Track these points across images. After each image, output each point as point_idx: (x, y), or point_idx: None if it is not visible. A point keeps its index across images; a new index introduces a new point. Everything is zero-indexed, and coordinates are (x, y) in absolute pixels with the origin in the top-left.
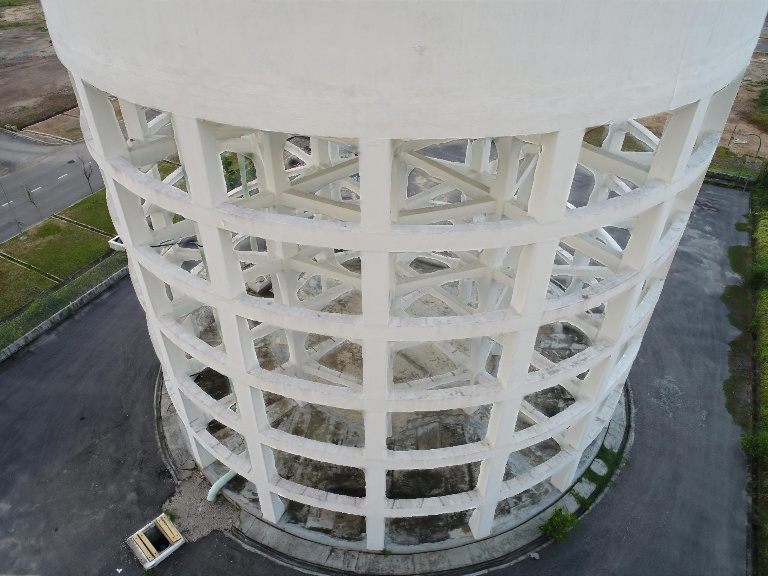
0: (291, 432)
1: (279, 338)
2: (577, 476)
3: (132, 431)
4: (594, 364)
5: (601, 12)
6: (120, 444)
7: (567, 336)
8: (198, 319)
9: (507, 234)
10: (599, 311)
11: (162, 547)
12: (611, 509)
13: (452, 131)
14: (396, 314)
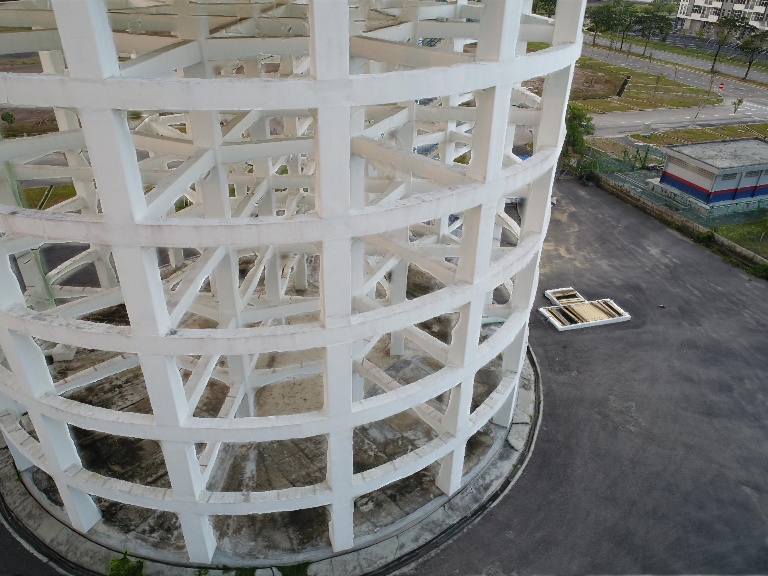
0: None
1: None
2: (227, 562)
3: (66, 300)
4: (101, 347)
5: None
6: None
7: None
8: None
9: None
10: (545, 453)
11: None
12: None
13: None
14: None
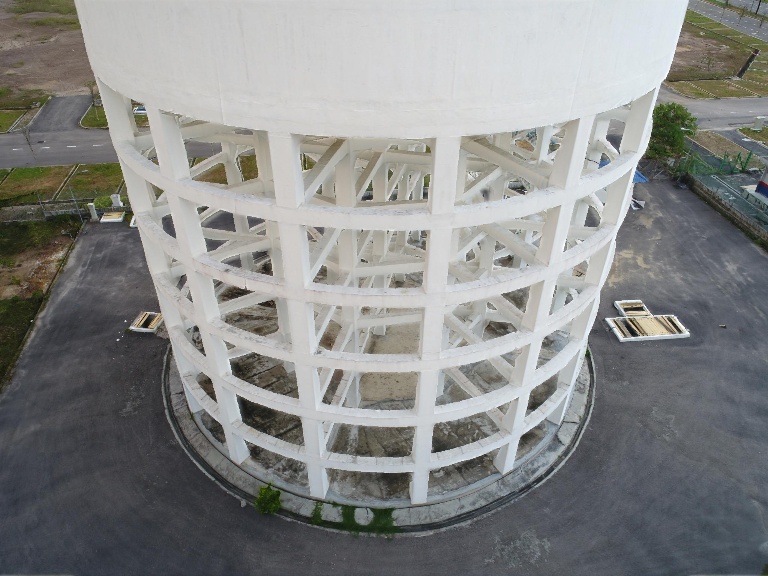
0: (256, 327)
1: None
2: (336, 500)
3: None
4: (271, 355)
5: (137, 22)
6: None
7: None
8: None
9: (148, 173)
10: (587, 449)
11: None
12: (326, 543)
13: (106, 81)
14: None
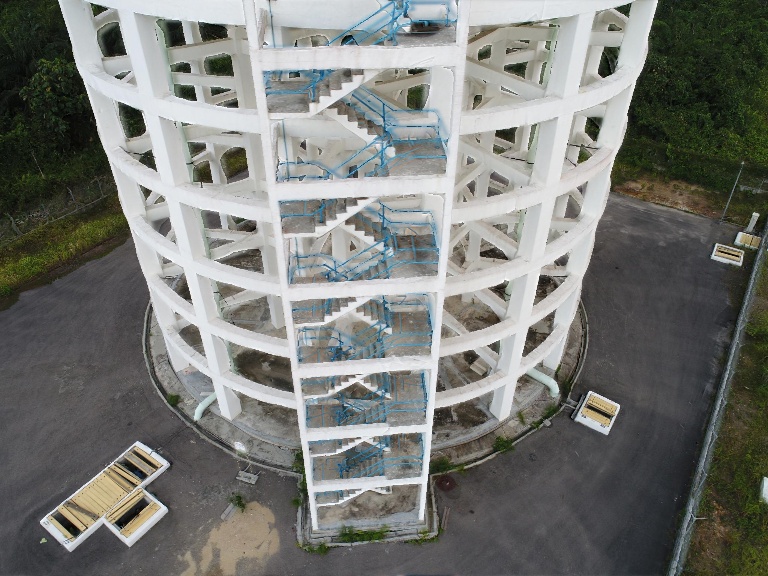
0: None
1: (476, 300)
2: None
3: None
4: None
5: None
6: None
7: None
8: None
9: None
10: (136, 318)
11: None
12: None
13: None
14: None
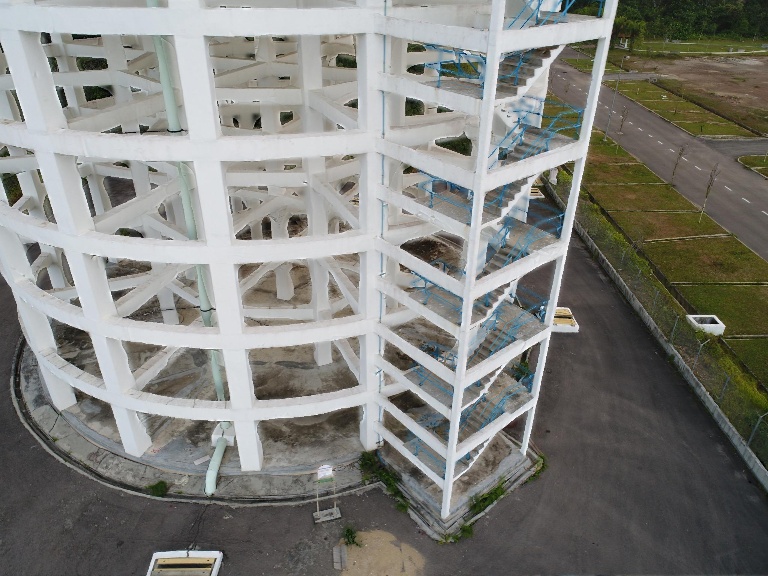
0: None
1: None
2: None
3: None
4: None
5: None
6: None
7: (80, 363)
8: None
9: None
10: (12, 432)
11: None
12: None
13: None
14: None
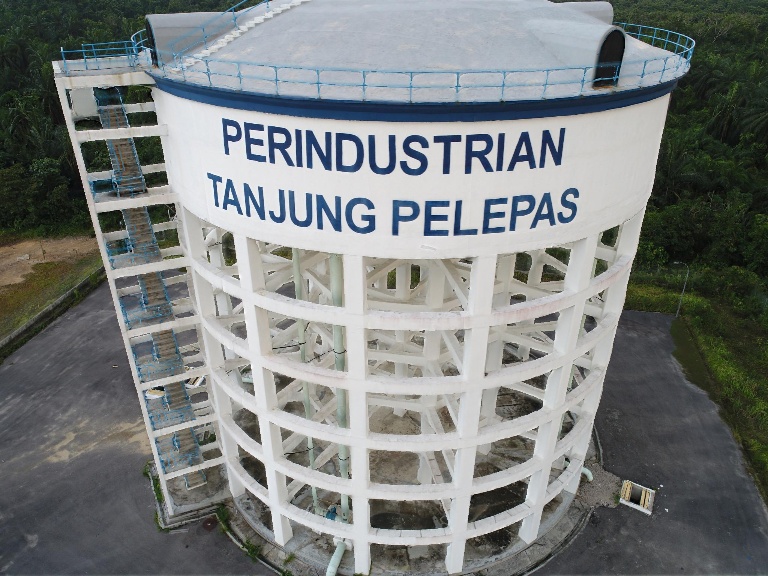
0: (515, 448)
1: None
2: None
3: (579, 567)
4: None
5: None
6: (596, 568)
7: None
8: (426, 575)
9: None
10: None
11: (633, 502)
12: None
13: None
14: (409, 376)
